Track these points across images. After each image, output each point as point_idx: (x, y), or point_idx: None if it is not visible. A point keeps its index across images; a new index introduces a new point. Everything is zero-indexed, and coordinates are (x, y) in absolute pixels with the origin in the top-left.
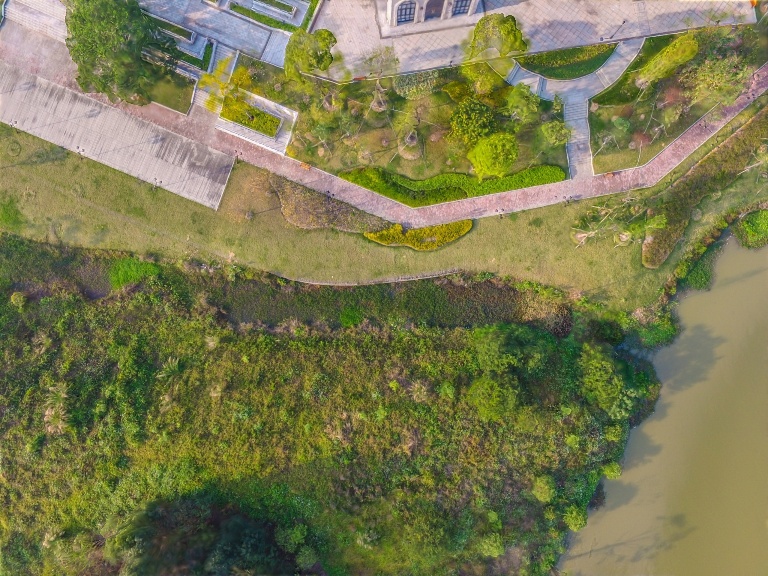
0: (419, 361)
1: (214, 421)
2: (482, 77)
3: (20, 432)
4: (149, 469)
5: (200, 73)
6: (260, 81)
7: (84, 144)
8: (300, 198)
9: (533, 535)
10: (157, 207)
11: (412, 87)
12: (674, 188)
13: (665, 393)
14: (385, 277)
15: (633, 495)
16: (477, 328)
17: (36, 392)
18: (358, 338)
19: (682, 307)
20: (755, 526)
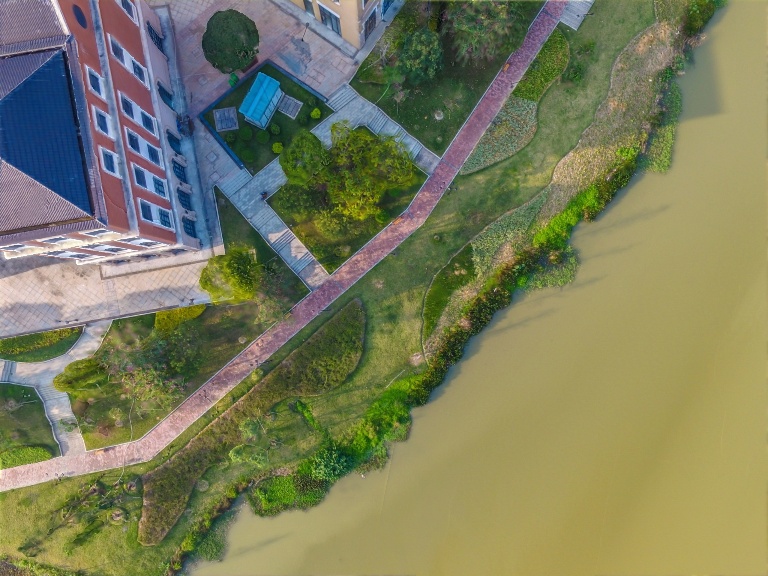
0: None
1: None
2: None
3: None
4: None
5: None
6: None
7: None
8: None
9: None
10: None
11: None
12: (169, 464)
13: None
14: None
15: None
16: None
17: None
18: None
19: None
20: None
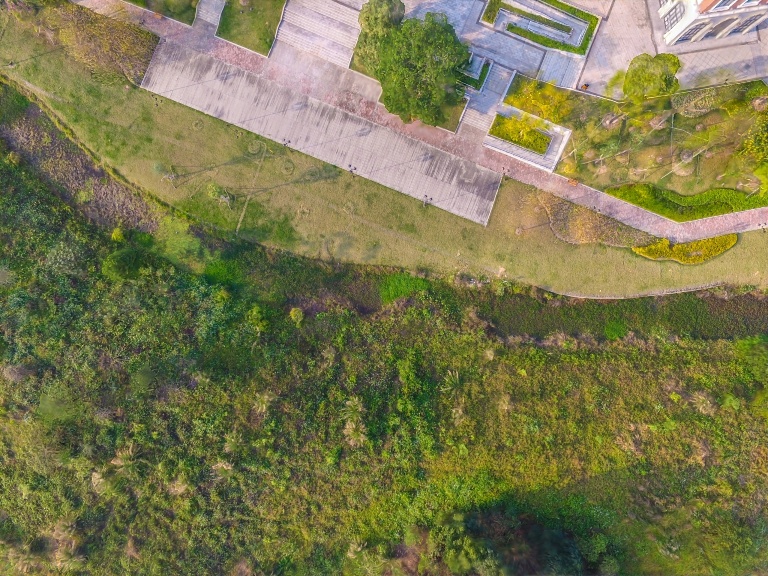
0: (692, 373)
1: (506, 433)
2: None
3: (319, 445)
4: (447, 481)
5: (471, 92)
6: None
7: (356, 162)
8: (568, 214)
9: None
10: (428, 224)
11: None
12: None
13: None
14: (650, 291)
15: None
16: (740, 340)
17: (329, 406)
18: (625, 350)
19: None
20: None
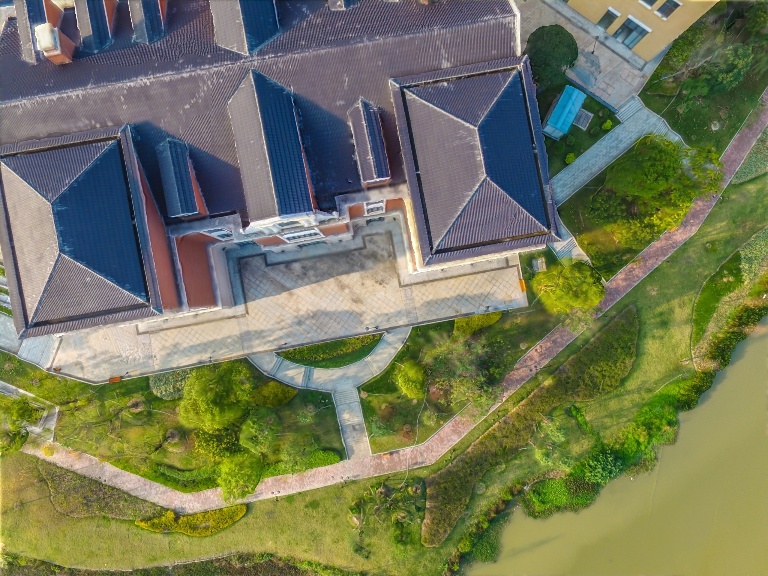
0: None
1: None
2: None
3: None
4: None
5: None
6: (18, 376)
7: None
8: (70, 486)
9: None
10: None
11: (169, 387)
12: (453, 467)
13: None
14: (160, 562)
15: None
16: None
17: None
18: None
19: None
20: None
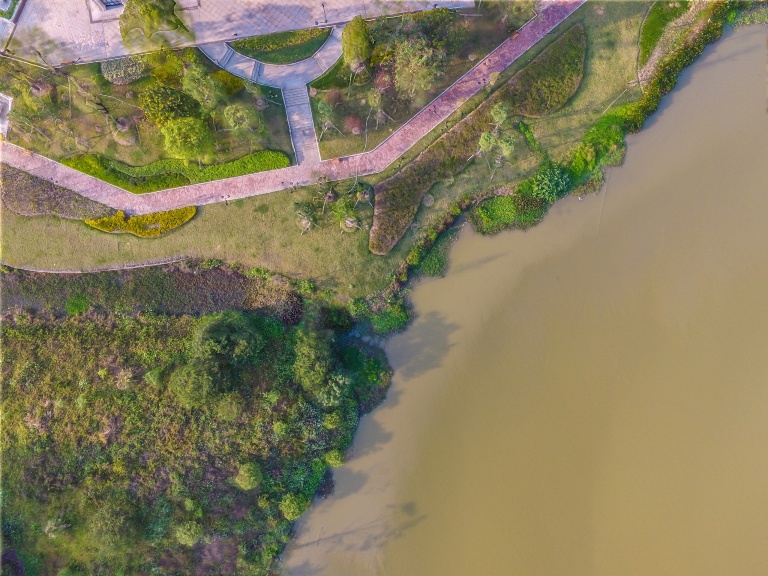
0: (136, 349)
1: None
2: (179, 61)
3: None
4: None
5: None
6: None
7: None
8: (22, 185)
9: (248, 524)
10: None
11: (120, 72)
12: (401, 174)
13: (397, 380)
14: (109, 264)
15: (363, 483)
16: (204, 316)
17: None
18: (81, 326)
19: (415, 294)
20: (485, 514)
